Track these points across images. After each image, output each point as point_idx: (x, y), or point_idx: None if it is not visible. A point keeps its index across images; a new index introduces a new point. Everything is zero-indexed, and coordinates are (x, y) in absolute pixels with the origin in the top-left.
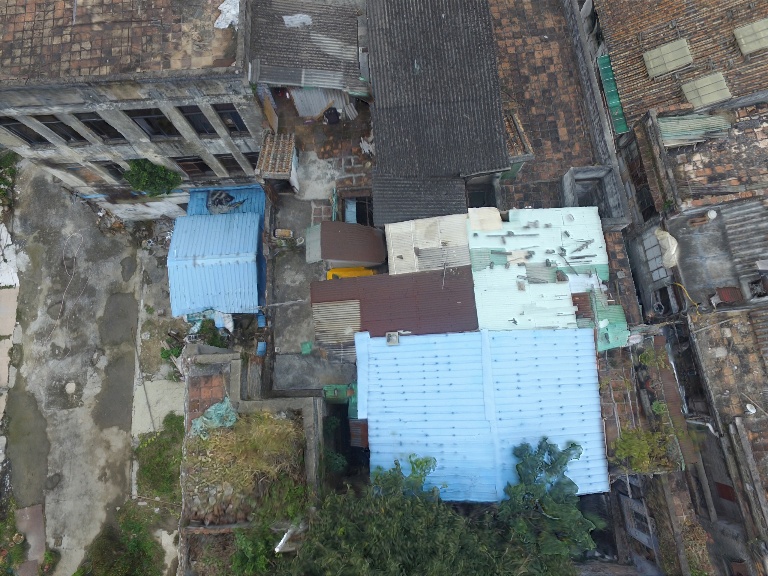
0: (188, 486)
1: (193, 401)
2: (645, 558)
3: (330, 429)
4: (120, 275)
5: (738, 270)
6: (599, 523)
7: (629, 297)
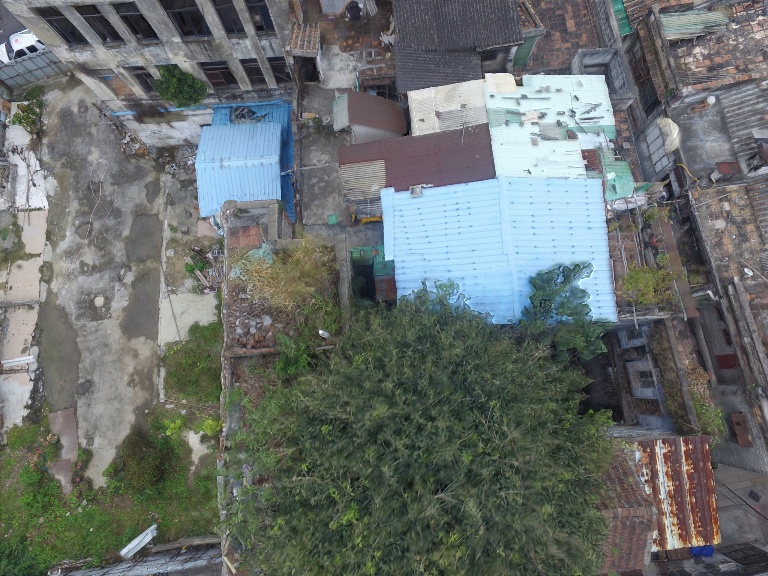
0: (230, 320)
1: (232, 248)
2: (650, 414)
3: (357, 286)
4: (145, 198)
5: (736, 149)
6: (606, 395)
7: (634, 170)
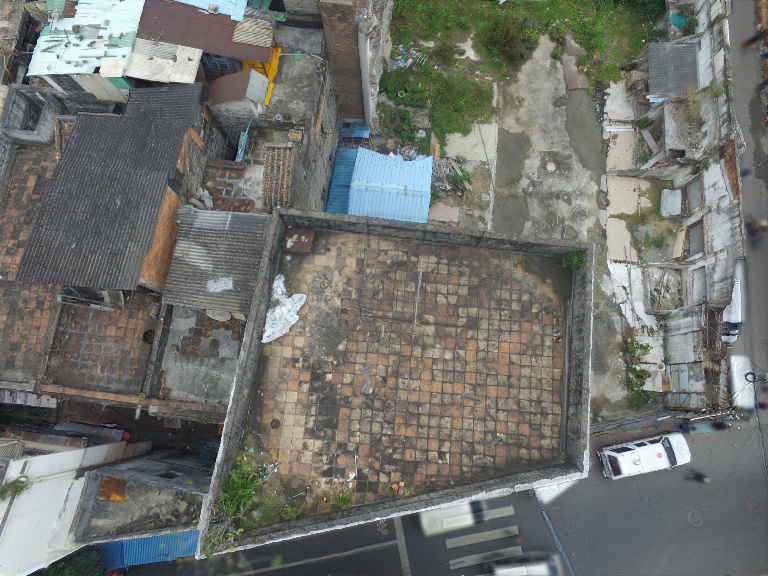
0: None
1: None
2: None
3: None
4: None
5: None
6: None
7: None
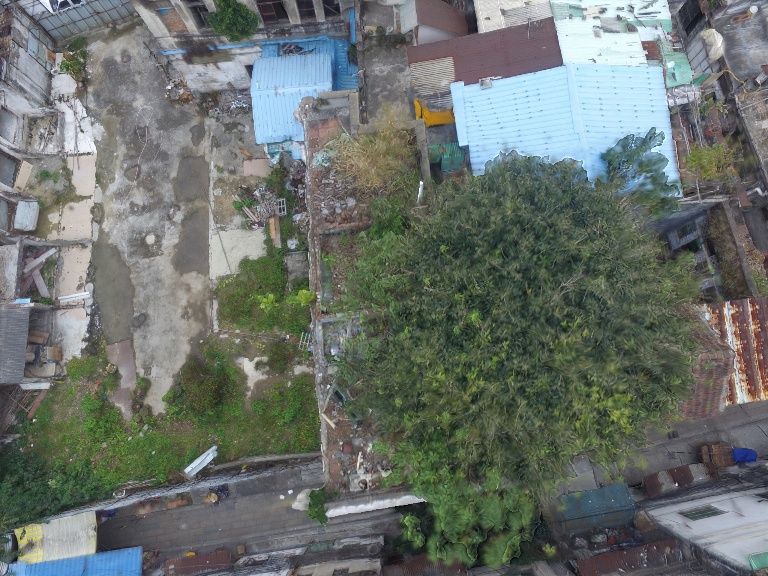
0: (315, 203)
1: (313, 139)
2: None
3: None
4: (190, 141)
5: None
6: None
7: None
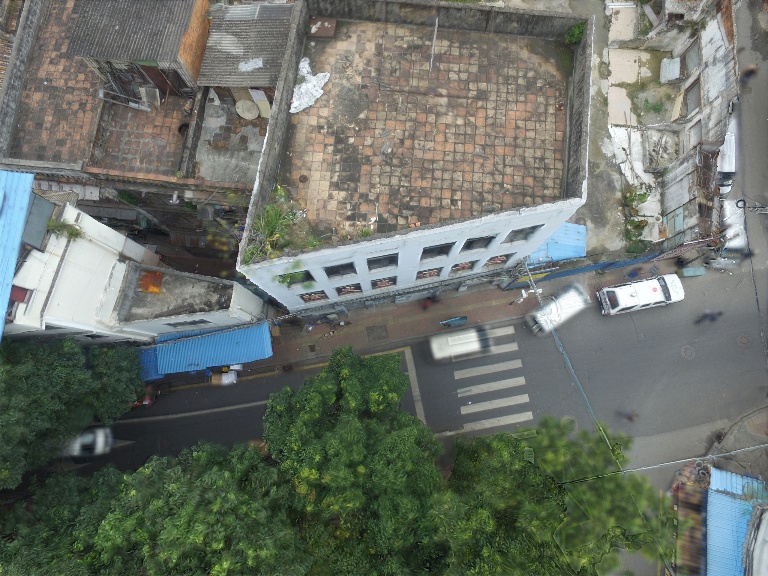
0: None
1: None
2: None
3: None
4: None
5: None
6: None
7: None
